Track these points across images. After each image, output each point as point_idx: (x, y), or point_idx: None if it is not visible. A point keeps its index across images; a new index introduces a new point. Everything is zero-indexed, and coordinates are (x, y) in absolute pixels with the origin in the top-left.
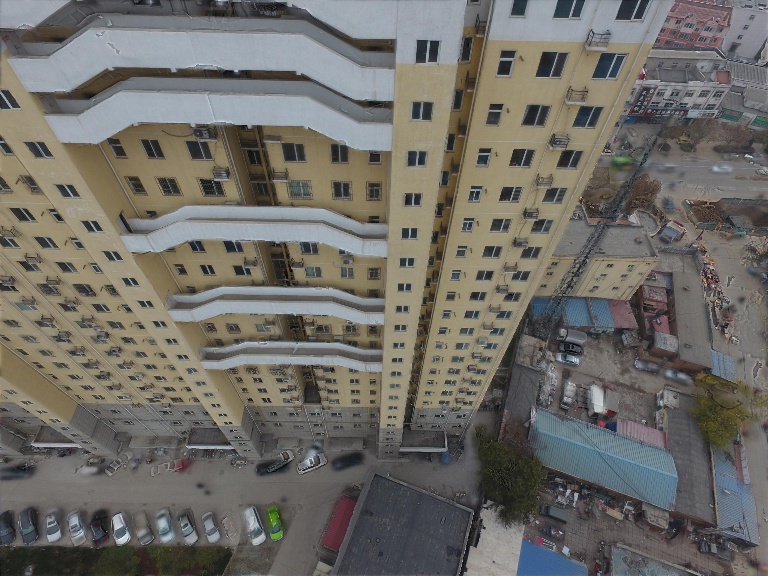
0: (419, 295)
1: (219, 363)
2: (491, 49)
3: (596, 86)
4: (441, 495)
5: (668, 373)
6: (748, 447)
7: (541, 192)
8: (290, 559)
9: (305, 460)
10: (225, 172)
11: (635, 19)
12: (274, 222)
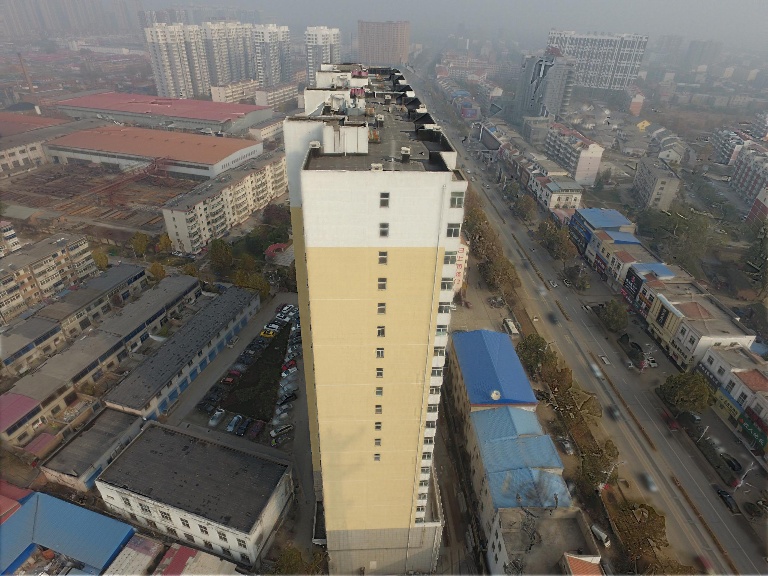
0: None
1: None
2: None
3: None
4: None
5: None
6: None
7: None
8: None
9: None
10: None
11: None
12: None
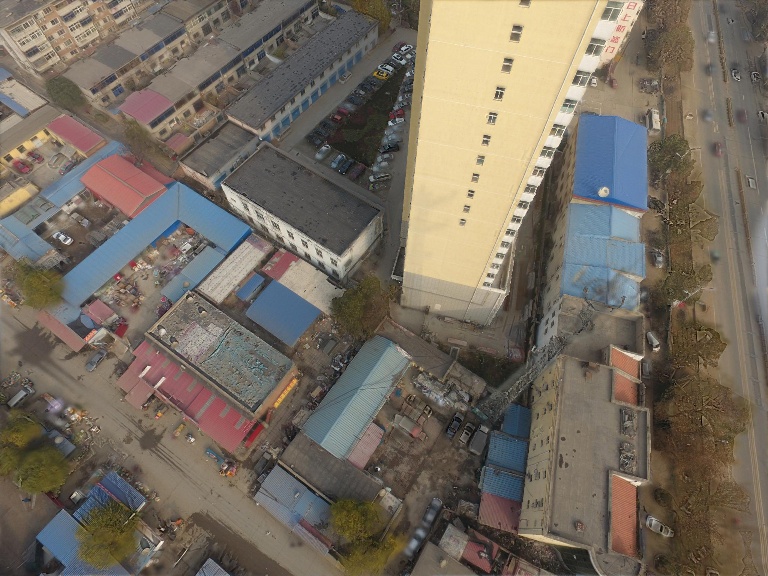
0: None
1: None
2: None
3: None
4: None
5: (421, 533)
6: (327, 570)
7: None
8: None
9: None
10: None
11: None
12: None
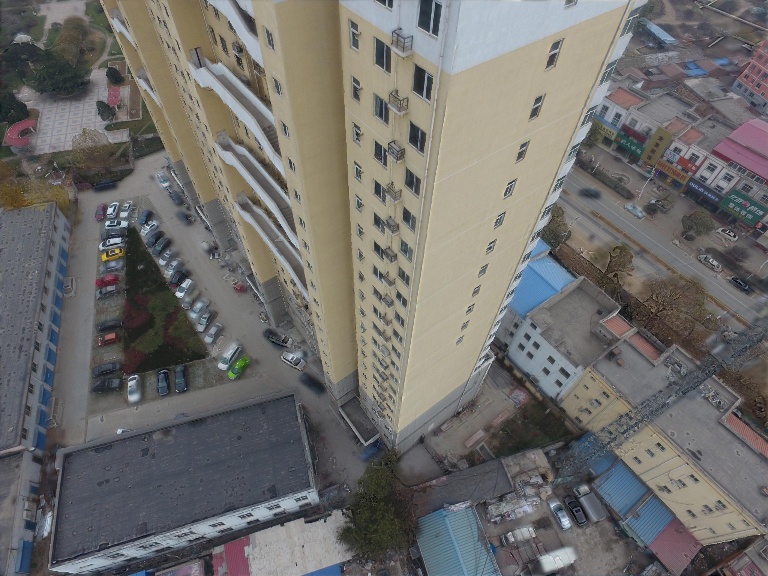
0: (310, 239)
1: (241, 211)
2: (343, 14)
3: (415, 102)
4: (335, 472)
5: None
6: None
7: (398, 206)
8: (223, 395)
9: (291, 353)
10: (236, 48)
11: (433, 34)
12: (236, 99)
